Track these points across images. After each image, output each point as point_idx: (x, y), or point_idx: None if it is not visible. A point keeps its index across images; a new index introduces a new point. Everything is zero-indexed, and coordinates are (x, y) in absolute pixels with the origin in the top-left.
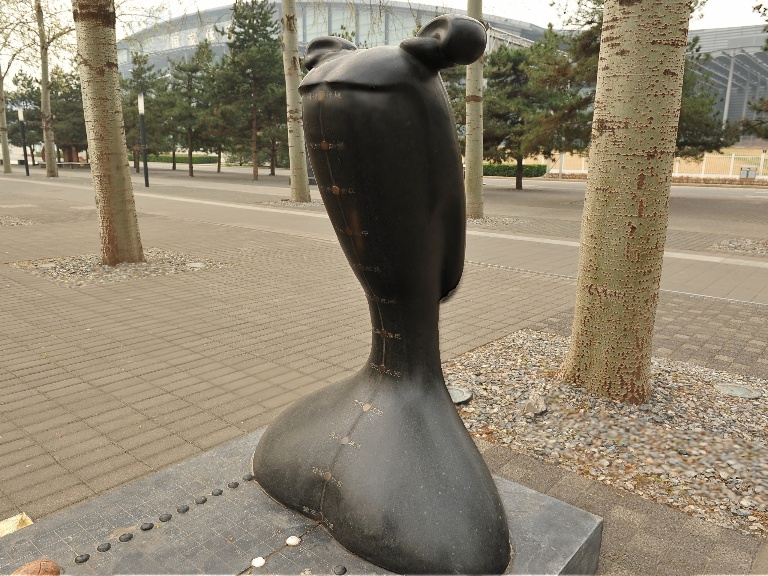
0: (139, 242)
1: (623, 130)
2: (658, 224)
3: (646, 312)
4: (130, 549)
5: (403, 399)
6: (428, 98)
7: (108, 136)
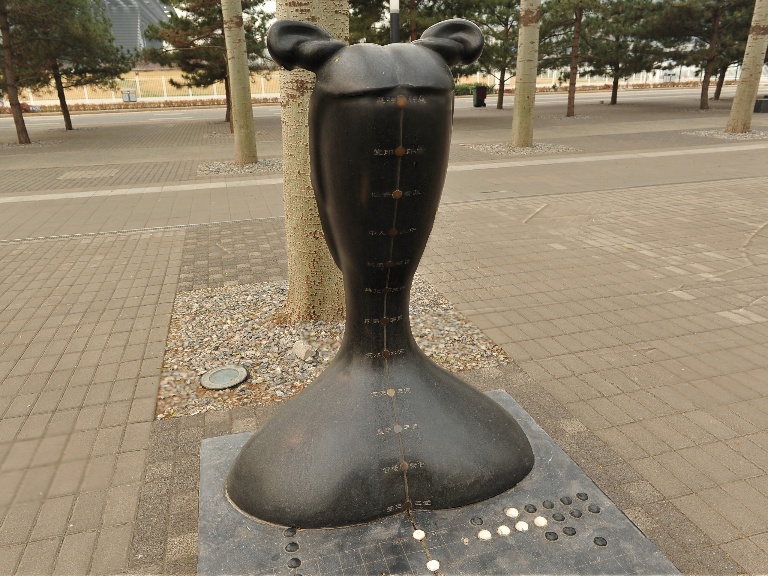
0: None
1: None
2: None
3: None
4: None
5: (415, 370)
6: None
7: None
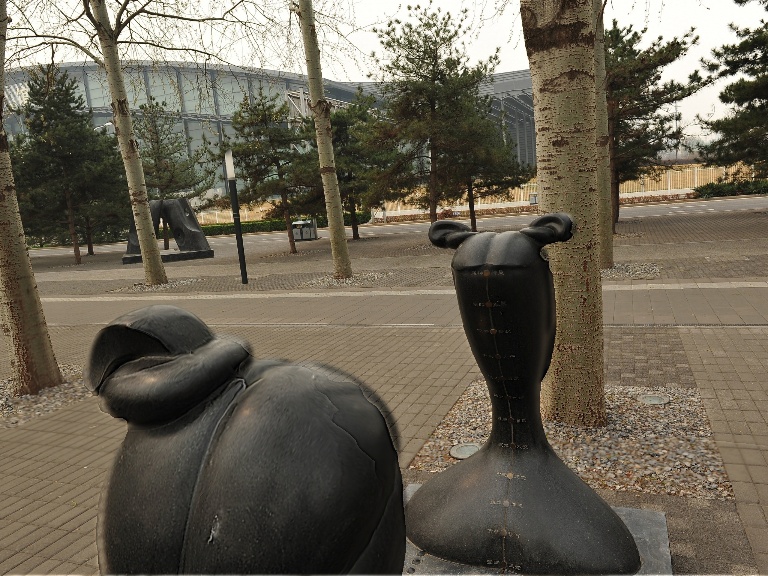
0: (56, 363)
1: None
2: (599, 293)
3: (599, 357)
4: None
5: (535, 464)
6: (547, 265)
7: (15, 261)
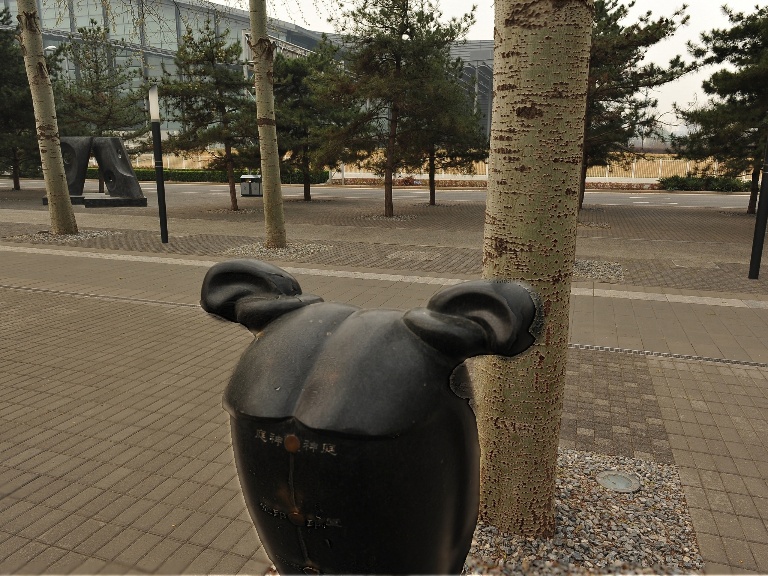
0: None
1: (527, 253)
2: (563, 349)
3: (554, 440)
4: None
5: None
6: (464, 412)
7: None
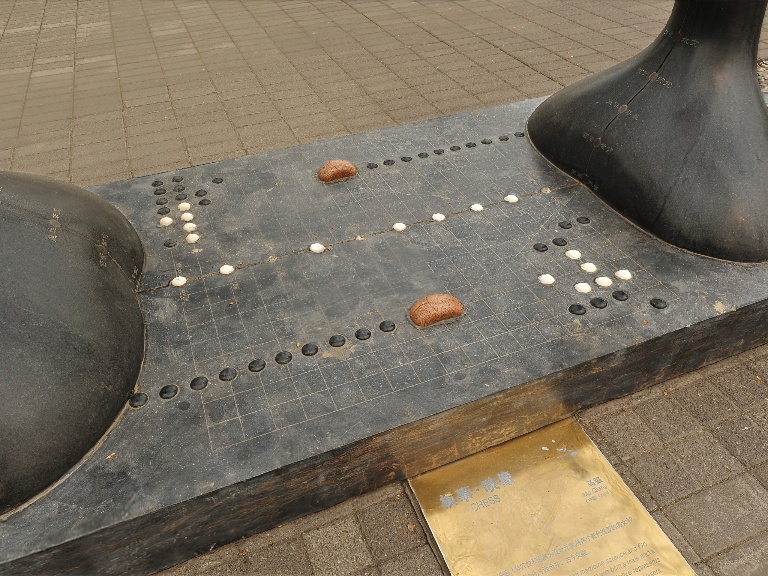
0: None
1: None
2: None
3: None
4: (337, 323)
5: None
6: None
7: None
